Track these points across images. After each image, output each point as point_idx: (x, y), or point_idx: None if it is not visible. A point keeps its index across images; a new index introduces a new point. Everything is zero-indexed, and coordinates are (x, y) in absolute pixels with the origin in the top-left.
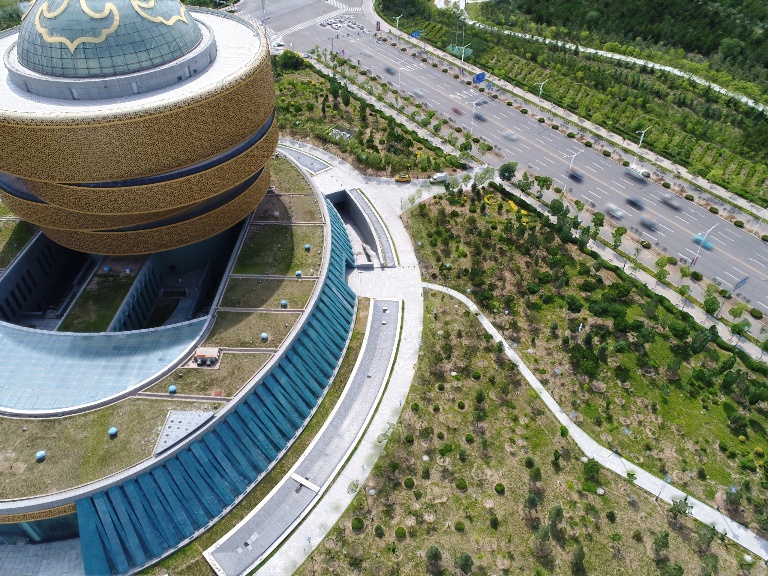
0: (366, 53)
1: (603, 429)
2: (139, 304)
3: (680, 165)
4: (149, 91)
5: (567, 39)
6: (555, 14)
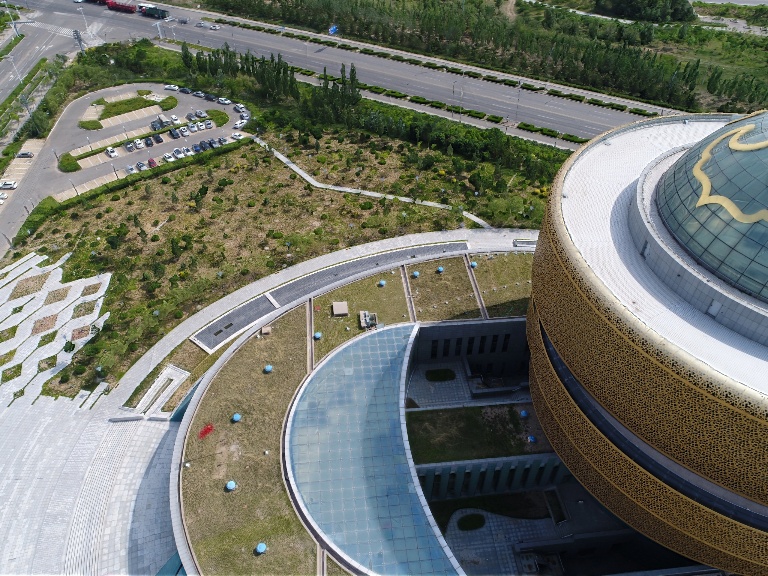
0: None
1: None
2: (498, 475)
3: None
4: (731, 328)
5: None
6: None
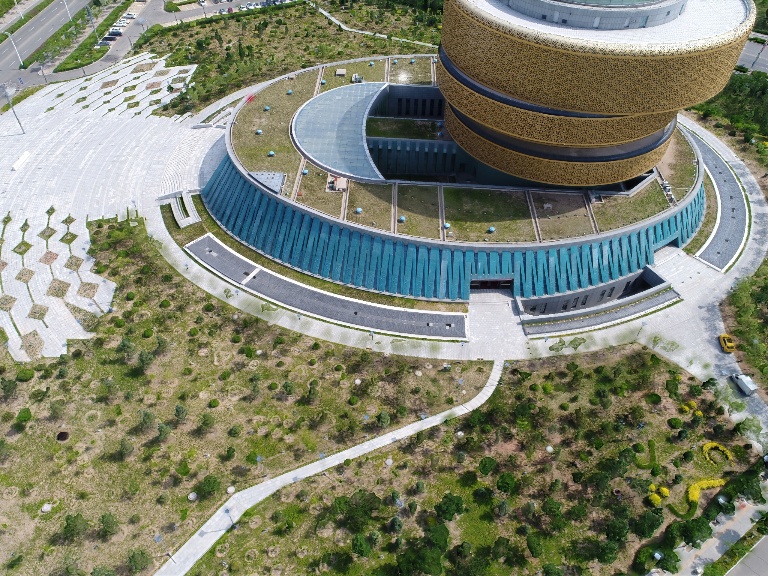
0: None
1: (267, 521)
2: (418, 156)
3: None
4: (517, 11)
5: None
6: None
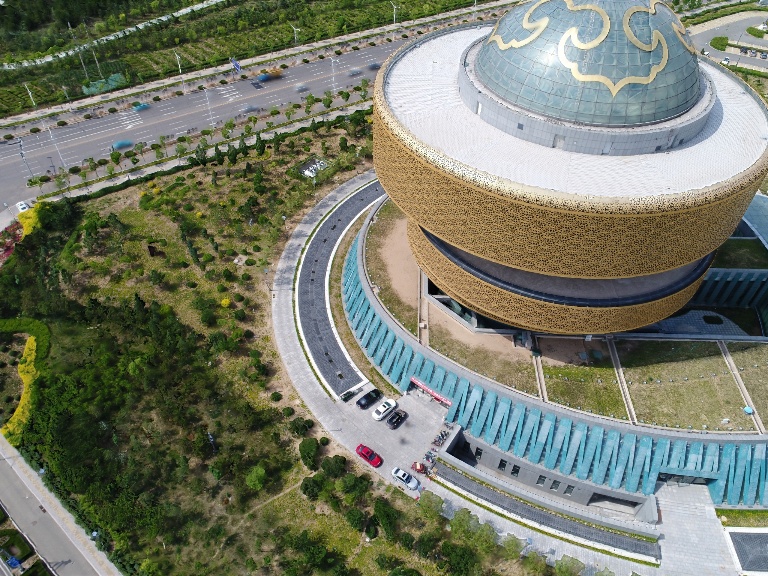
0: (51, 153)
1: None
2: None
3: (391, 24)
4: None
5: (136, 20)
6: (80, 9)
